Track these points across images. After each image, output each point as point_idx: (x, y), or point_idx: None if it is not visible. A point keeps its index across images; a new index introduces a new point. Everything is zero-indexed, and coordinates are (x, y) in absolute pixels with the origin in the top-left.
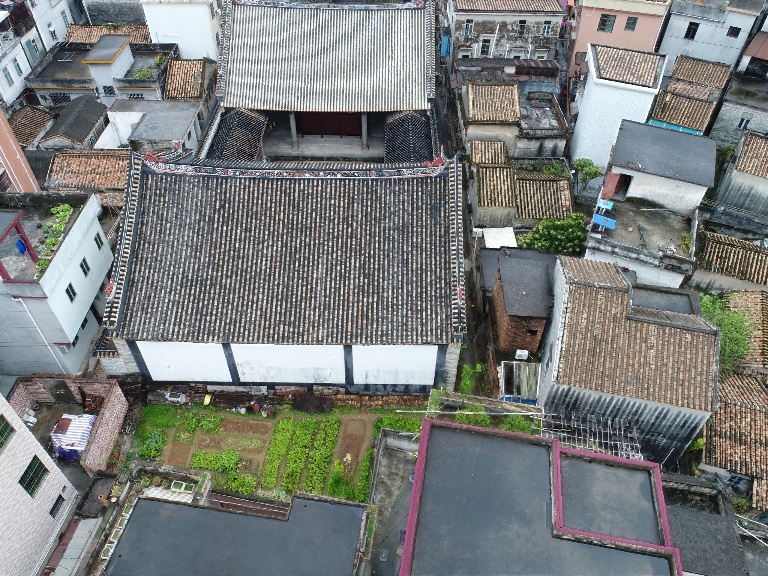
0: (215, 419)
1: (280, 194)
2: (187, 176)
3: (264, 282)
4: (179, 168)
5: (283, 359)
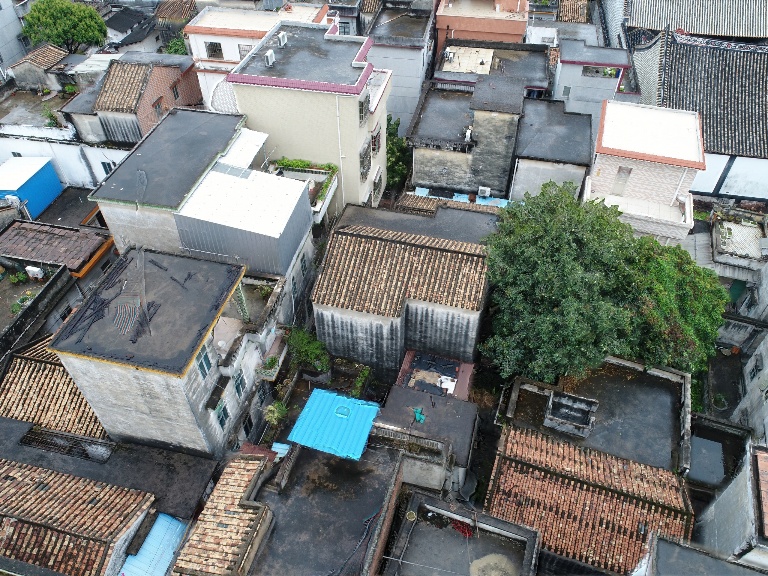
0: (699, 216)
1: (767, 64)
2: (699, 47)
3: (760, 120)
4: (696, 40)
5: (765, 175)
